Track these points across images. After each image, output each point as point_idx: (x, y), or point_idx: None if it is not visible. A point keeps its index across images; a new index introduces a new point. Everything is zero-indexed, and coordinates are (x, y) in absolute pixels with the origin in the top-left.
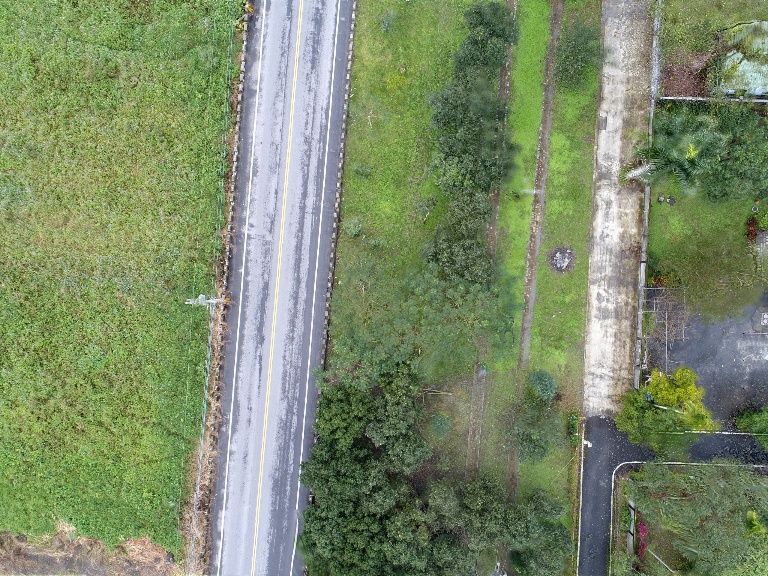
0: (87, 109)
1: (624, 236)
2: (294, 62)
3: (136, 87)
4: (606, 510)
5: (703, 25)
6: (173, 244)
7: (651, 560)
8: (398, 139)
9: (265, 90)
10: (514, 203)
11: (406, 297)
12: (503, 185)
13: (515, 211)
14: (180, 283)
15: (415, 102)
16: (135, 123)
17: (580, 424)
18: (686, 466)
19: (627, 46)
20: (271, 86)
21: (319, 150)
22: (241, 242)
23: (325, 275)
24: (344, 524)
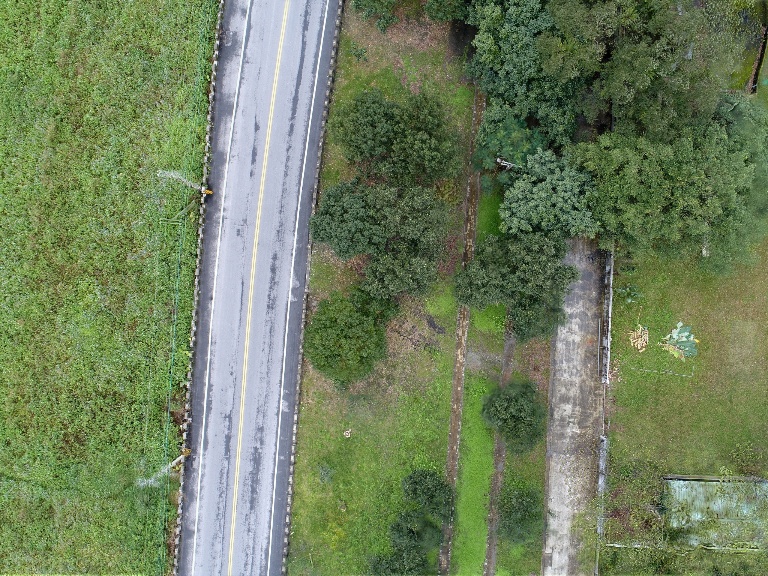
0: (22, 549)
1: None
2: (232, 503)
3: (71, 527)
4: None
5: (649, 464)
6: None
7: None
8: None
9: (203, 531)
10: None
11: None
12: None
13: None
14: None
15: (357, 539)
16: (71, 564)
17: None
18: None
19: (572, 483)
20: (209, 527)
21: None
22: None
23: None
24: None
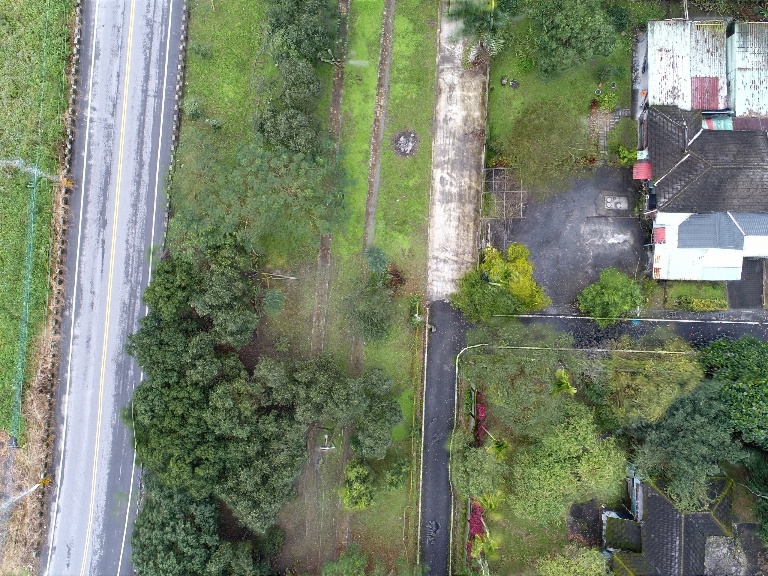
0: None
1: (467, 119)
2: None
3: None
4: (450, 394)
5: None
6: (16, 128)
7: (482, 434)
8: (241, 23)
9: None
10: (357, 87)
11: (233, 169)
12: (347, 69)
13: (359, 95)
14: (22, 166)
15: None
16: None
17: (424, 308)
18: (530, 350)
19: None
20: None
21: (161, 33)
22: (83, 125)
23: (168, 158)
24: (167, 393)
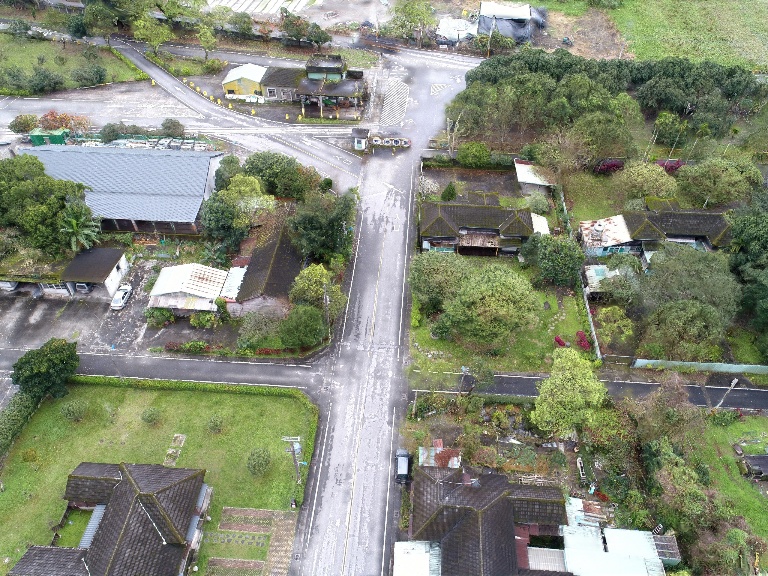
0: None
1: None
2: None
3: None
4: None
5: None
6: None
7: None
8: None
9: None
10: None
11: None
12: None
13: None
14: None
15: None
16: None
17: (764, 162)
18: None
19: None
20: None
21: None
22: None
23: None
24: None
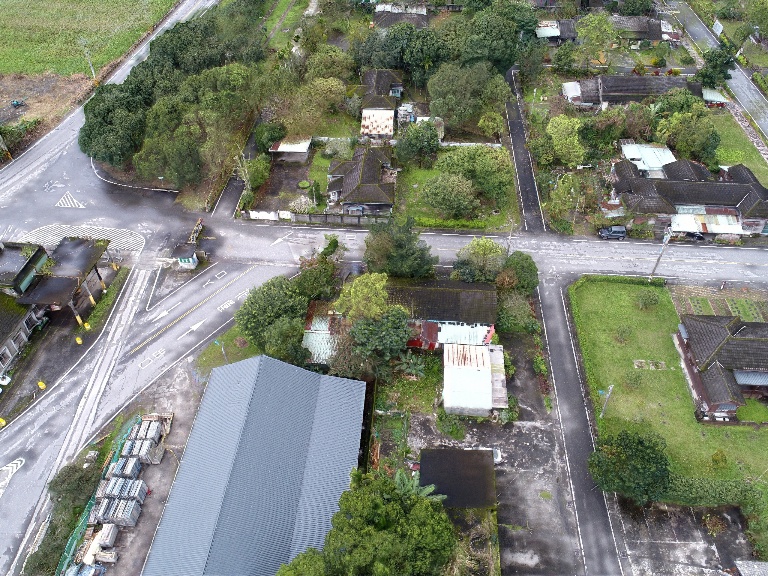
0: (123, 6)
1: None
2: None
3: (143, 3)
4: None
5: None
6: None
7: None
8: None
9: (188, 3)
10: (271, 21)
11: None
12: (268, 19)
13: None
14: None
15: None
16: (138, 8)
17: None
18: None
19: None
20: None
21: None
22: None
23: None
24: None
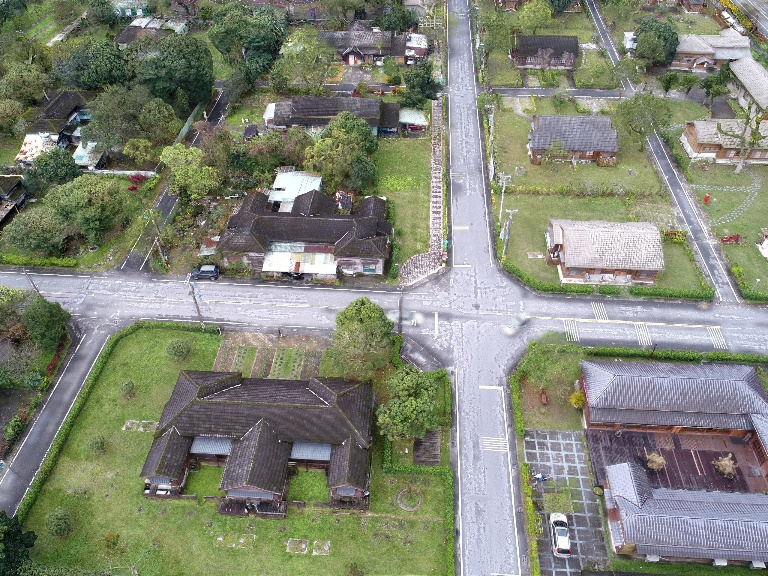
0: None
1: None
2: None
3: None
4: None
5: None
6: None
7: None
8: None
9: None
10: None
11: None
12: None
13: None
14: None
15: None
16: None
17: None
18: None
19: None
20: None
21: None
22: None
23: None
24: None
